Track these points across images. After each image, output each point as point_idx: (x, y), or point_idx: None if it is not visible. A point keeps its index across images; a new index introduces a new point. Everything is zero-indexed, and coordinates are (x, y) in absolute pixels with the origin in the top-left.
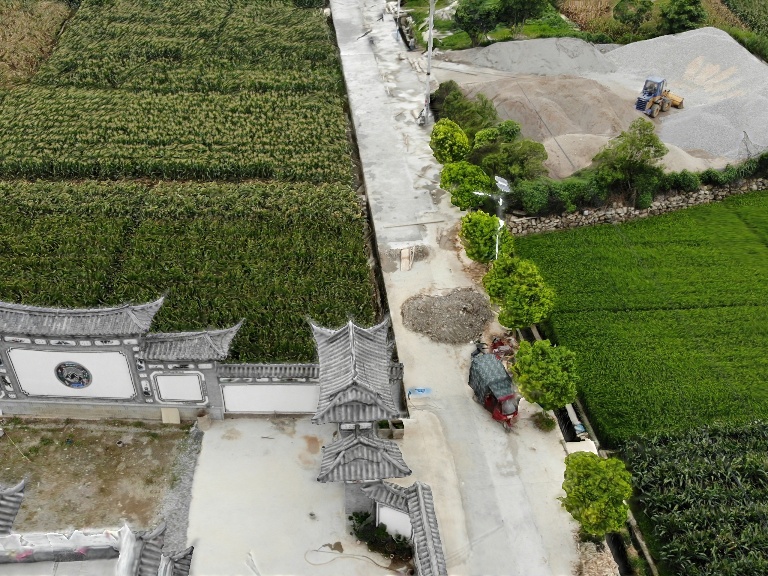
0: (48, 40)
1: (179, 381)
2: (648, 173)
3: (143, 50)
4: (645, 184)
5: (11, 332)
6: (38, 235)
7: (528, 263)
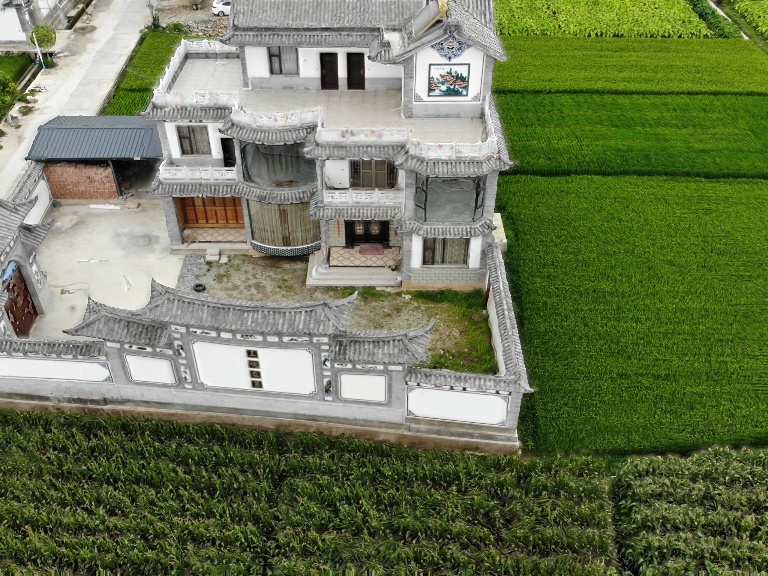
0: None
1: None
2: None
3: None
4: None
5: None
6: None
7: None
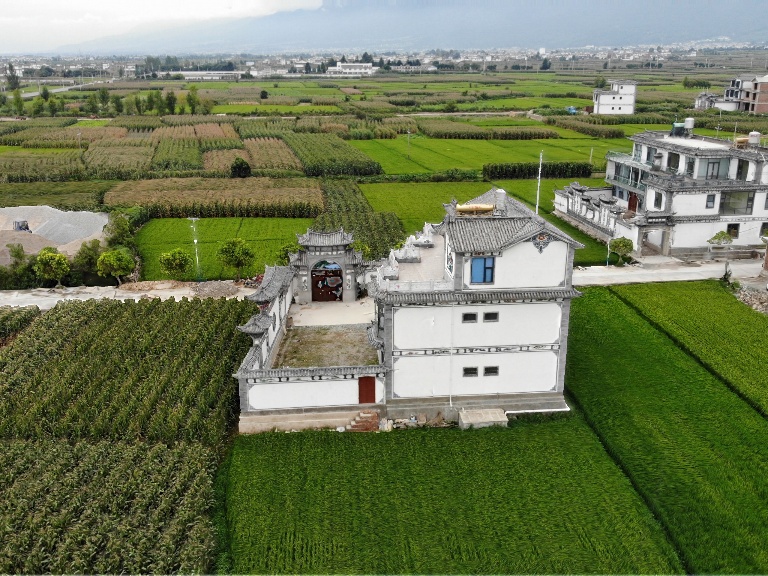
0: None
1: None
2: None
3: None
4: None
5: None
6: None
7: None
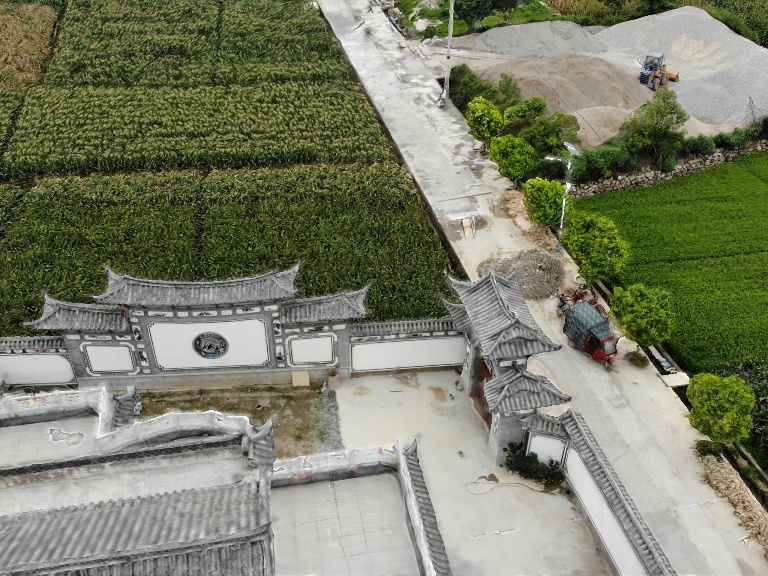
0: (45, 42)
1: (312, 344)
2: (672, 138)
3: (147, 48)
4: (670, 149)
5: (161, 305)
6: None
7: (604, 219)
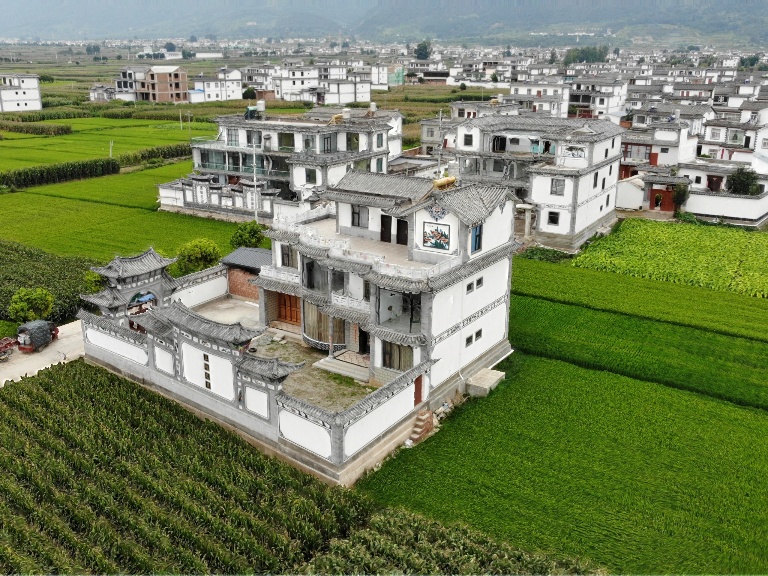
0: None
1: None
2: None
3: None
4: None
5: None
6: (57, 572)
7: None
